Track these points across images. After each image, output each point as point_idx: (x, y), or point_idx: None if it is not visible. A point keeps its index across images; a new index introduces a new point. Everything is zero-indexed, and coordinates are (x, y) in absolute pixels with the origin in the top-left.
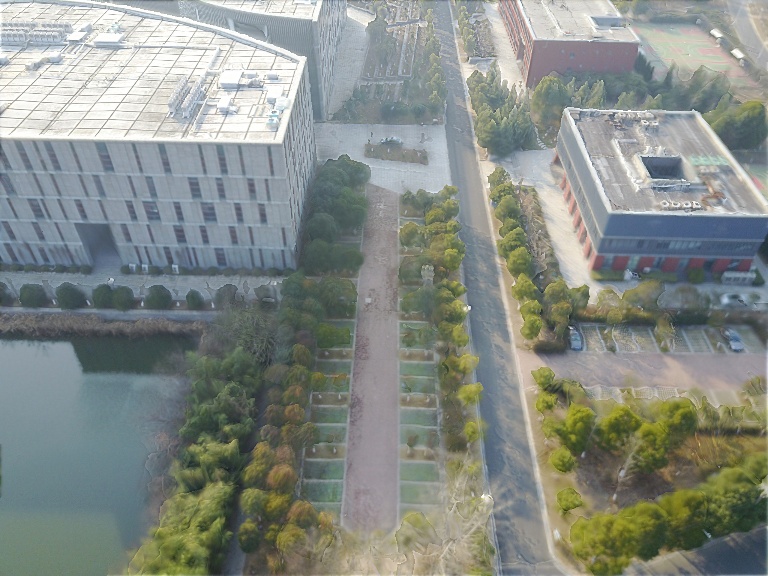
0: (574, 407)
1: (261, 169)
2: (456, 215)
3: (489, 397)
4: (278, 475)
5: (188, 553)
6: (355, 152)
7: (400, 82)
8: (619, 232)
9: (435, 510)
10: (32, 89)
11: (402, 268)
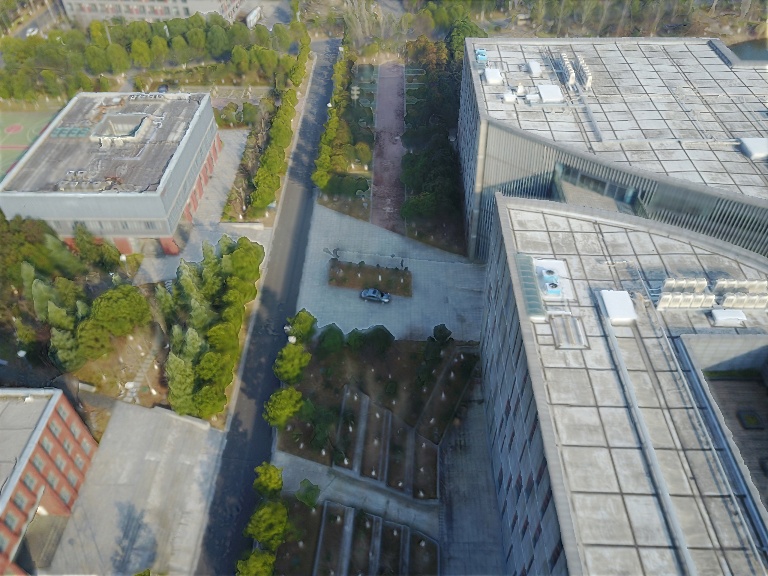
0: None
1: None
2: None
3: (326, 94)
4: None
5: None
6: (424, 280)
7: (351, 496)
8: None
9: None
10: (738, 82)
11: None
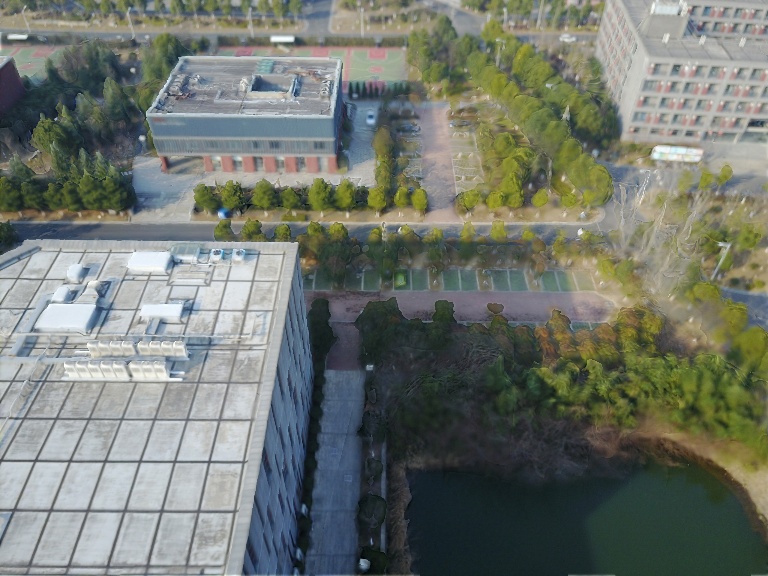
0: (508, 181)
1: (298, 291)
2: (260, 230)
3: None
4: (610, 331)
5: (709, 357)
6: None
7: None
8: (335, 128)
9: (577, 274)
10: None
11: (339, 272)
